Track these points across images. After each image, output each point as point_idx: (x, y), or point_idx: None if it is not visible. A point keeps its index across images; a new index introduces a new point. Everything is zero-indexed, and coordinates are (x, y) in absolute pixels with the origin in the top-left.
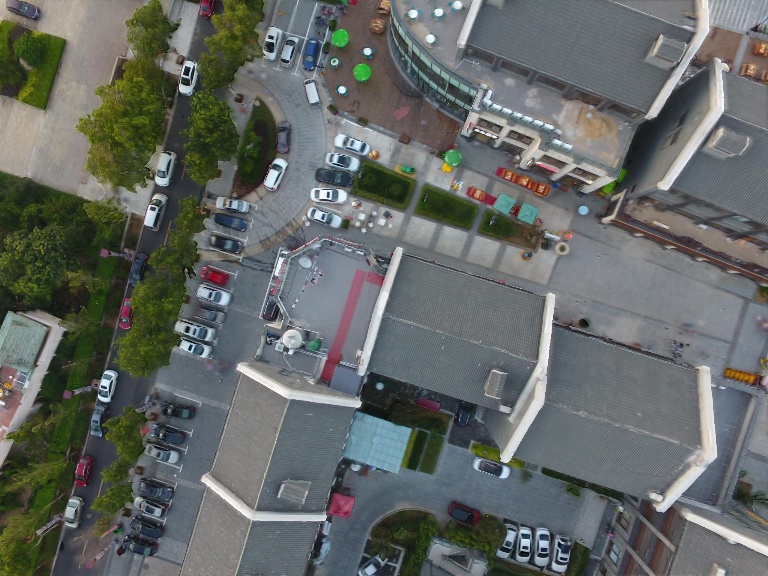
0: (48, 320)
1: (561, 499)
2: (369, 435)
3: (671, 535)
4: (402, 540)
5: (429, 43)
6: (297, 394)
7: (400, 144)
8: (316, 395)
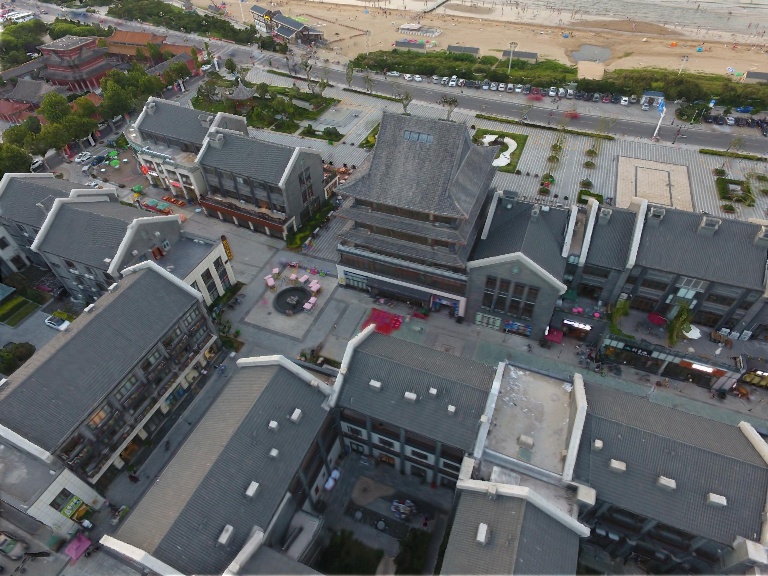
0: None
1: None
2: None
3: None
4: None
5: (132, 136)
6: None
7: (119, 188)
8: None
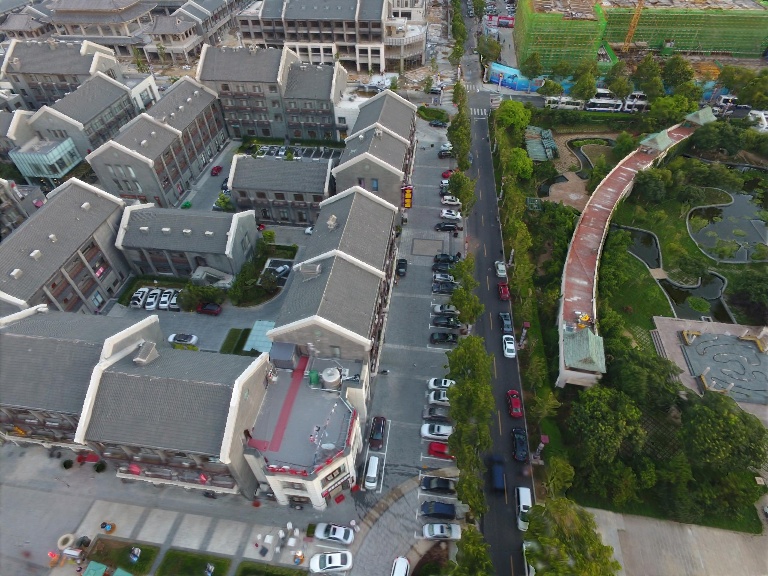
0: (575, 377)
1: None
2: None
3: (45, 301)
4: (257, 288)
5: None
6: (309, 320)
7: None
8: (297, 325)
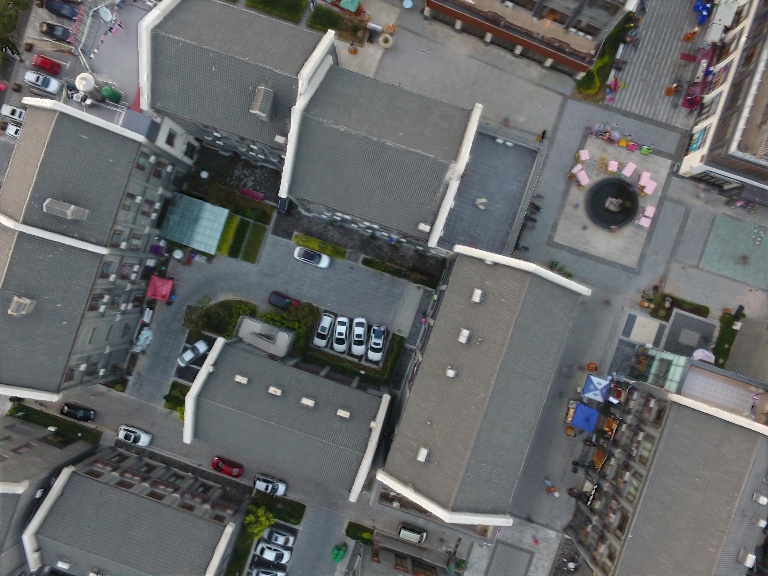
0: None
1: (381, 291)
2: (186, 216)
3: None
4: (221, 327)
5: None
6: (64, 106)
7: None
8: None
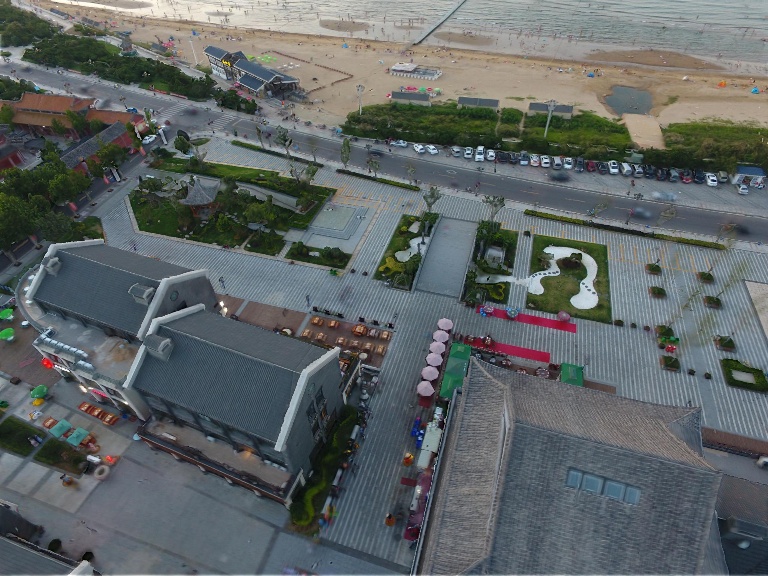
0: None
1: None
2: None
3: None
4: None
5: (27, 304)
6: None
7: (11, 385)
8: None
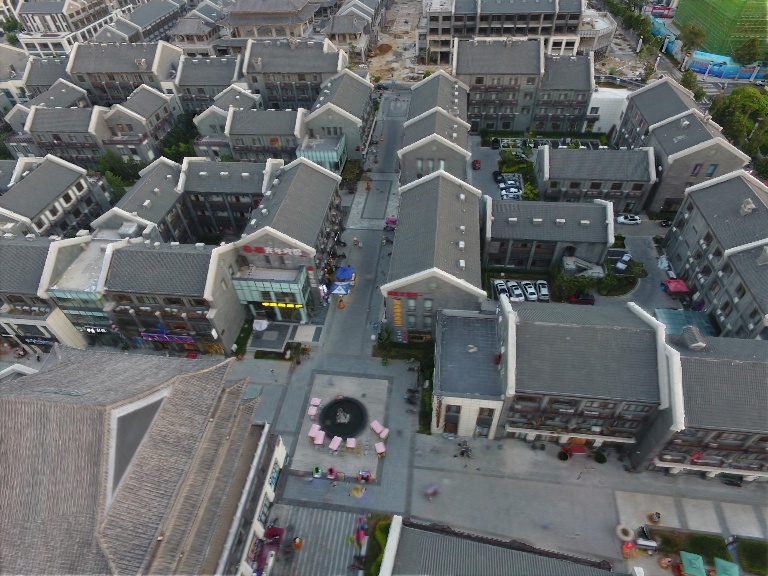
0: None
1: None
2: None
3: None
4: None
5: None
6: None
7: None
8: None
